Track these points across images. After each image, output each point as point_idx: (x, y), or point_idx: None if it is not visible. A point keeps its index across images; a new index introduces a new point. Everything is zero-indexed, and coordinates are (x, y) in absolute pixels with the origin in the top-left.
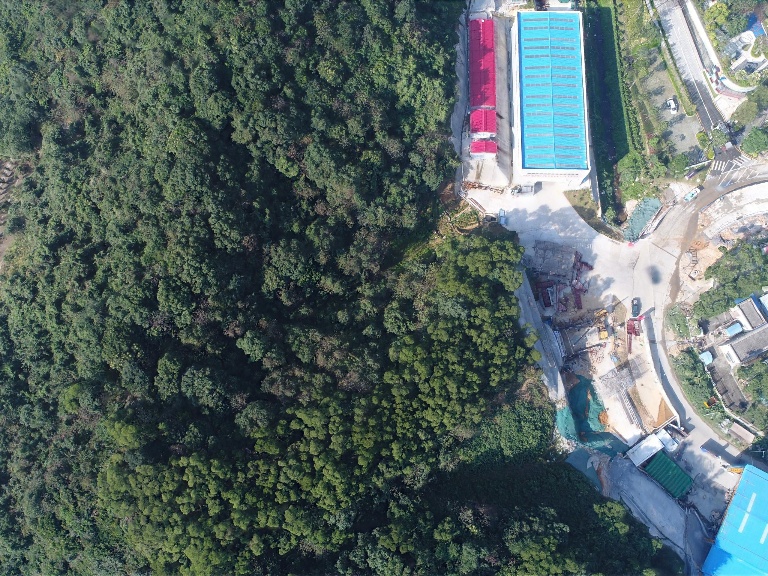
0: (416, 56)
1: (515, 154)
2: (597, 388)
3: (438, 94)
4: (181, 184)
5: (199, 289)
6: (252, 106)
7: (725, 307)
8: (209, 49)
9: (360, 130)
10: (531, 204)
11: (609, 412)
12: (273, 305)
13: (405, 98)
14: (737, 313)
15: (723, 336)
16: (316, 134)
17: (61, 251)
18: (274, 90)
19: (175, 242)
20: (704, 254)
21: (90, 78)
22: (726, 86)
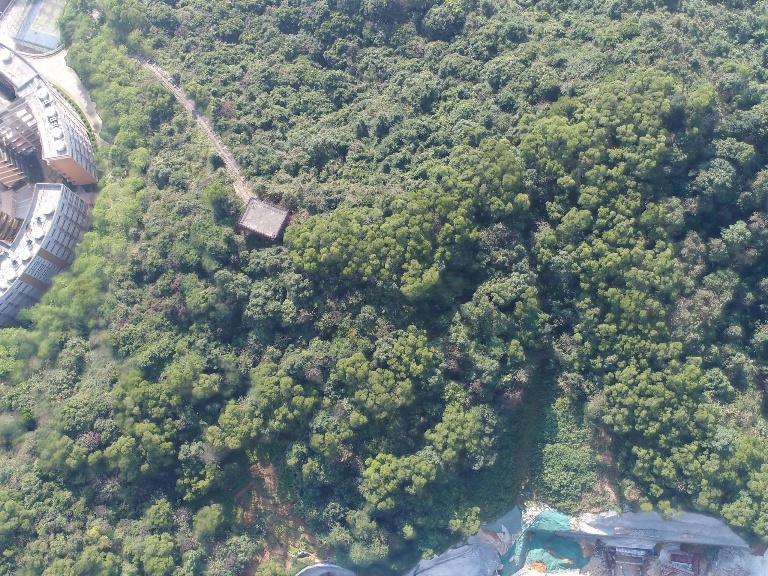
0: None
1: None
2: (573, 572)
3: None
4: None
5: None
6: None
7: None
8: None
9: None
10: None
11: (544, 575)
12: (764, 269)
13: None
14: None
15: None
16: None
17: None
18: None
19: None
20: None
21: None
22: None
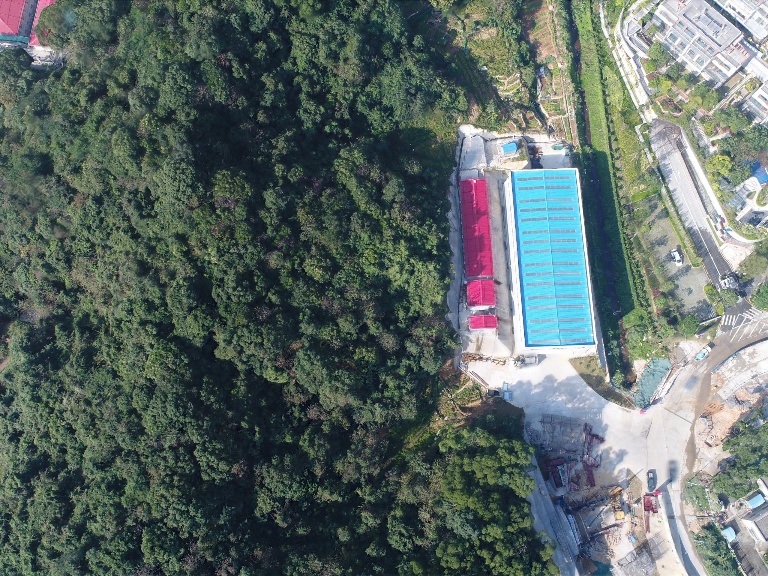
0: (407, 238)
1: (516, 322)
2: (616, 575)
3: (433, 277)
4: (162, 416)
5: (187, 533)
6: (235, 320)
7: (748, 490)
8: (186, 261)
9: (352, 328)
10: (535, 375)
11: None
12: (268, 526)
13: (398, 283)
14: (758, 483)
15: (745, 508)
16: (305, 339)
17: (34, 481)
18: (258, 297)
19: (158, 483)
20: (719, 418)
21: (59, 273)
22: (732, 237)
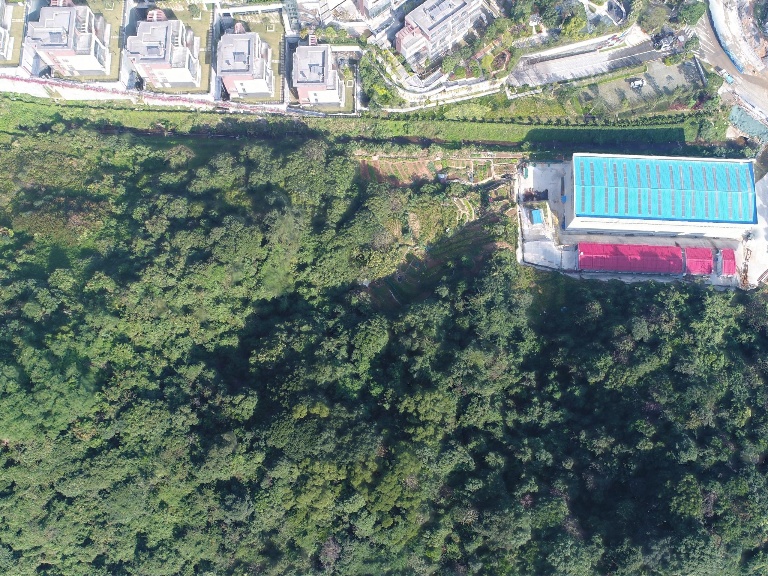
0: None
1: None
2: None
3: (717, 300)
4: None
5: None
6: None
7: None
8: None
9: None
10: (759, 223)
11: None
12: None
13: None
14: None
15: None
16: None
17: None
18: None
19: None
20: None
21: None
22: None
